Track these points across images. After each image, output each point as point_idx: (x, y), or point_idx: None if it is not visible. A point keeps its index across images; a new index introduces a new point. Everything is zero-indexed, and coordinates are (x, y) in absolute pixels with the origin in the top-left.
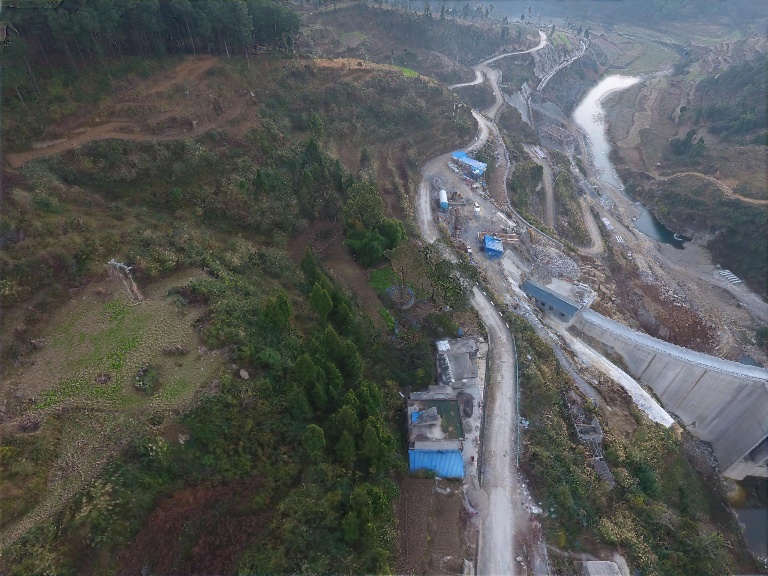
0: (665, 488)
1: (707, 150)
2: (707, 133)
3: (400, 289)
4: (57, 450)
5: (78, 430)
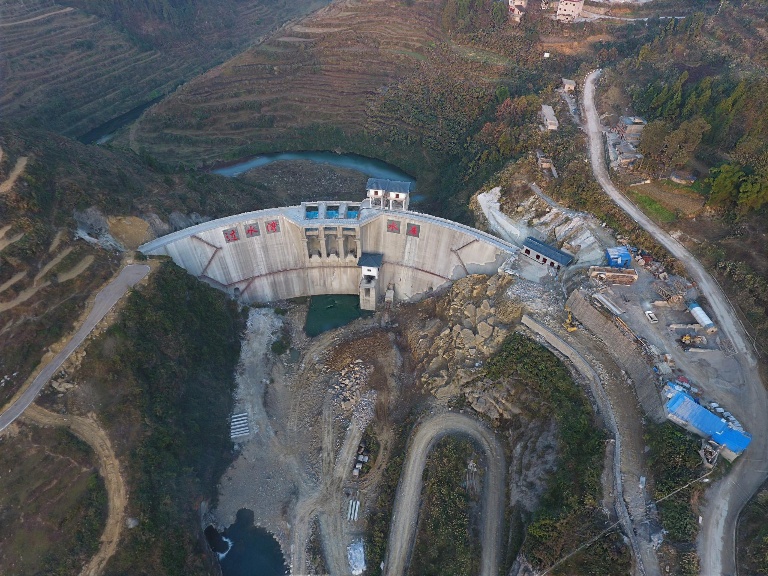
0: None
1: None
2: None
3: (686, 178)
4: (762, 64)
5: (763, 66)
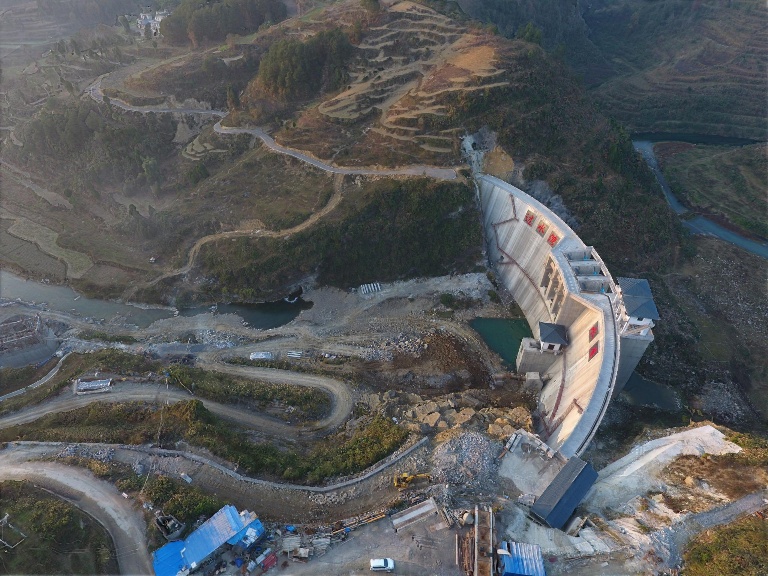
0: None
1: (176, 214)
2: (128, 198)
3: None
4: None
5: None
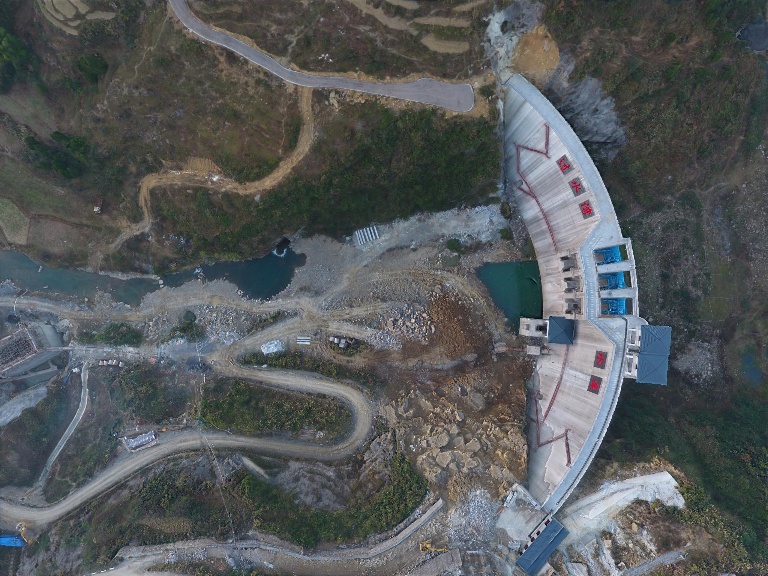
0: None
1: (95, 146)
2: (5, 97)
3: None
4: None
5: None
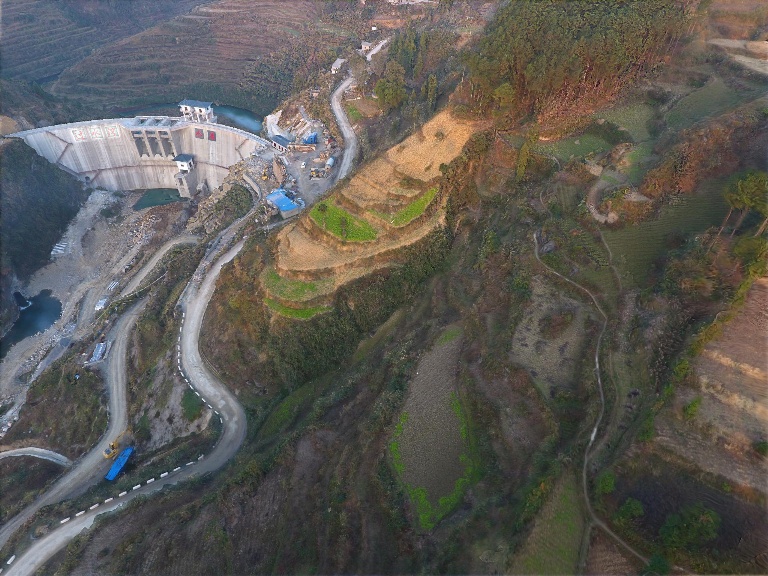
0: None
1: None
2: None
3: None
4: None
5: None
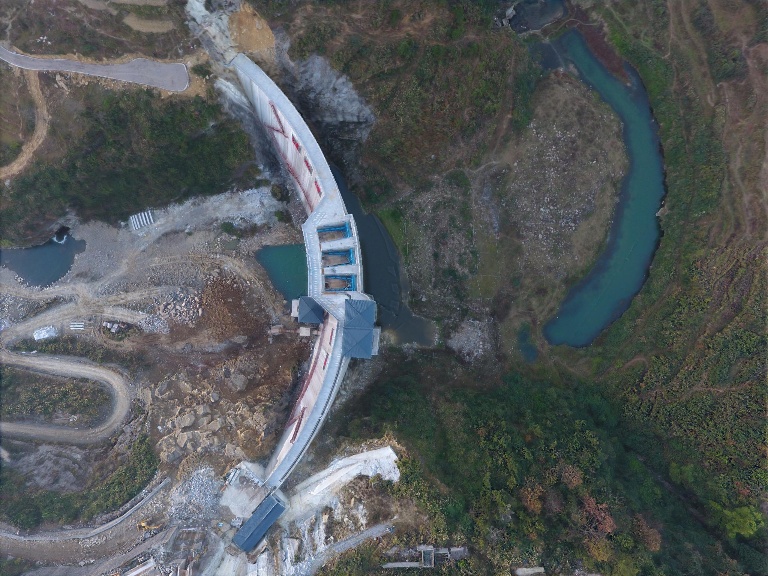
0: (434, 460)
1: None
2: None
3: None
4: None
5: None
